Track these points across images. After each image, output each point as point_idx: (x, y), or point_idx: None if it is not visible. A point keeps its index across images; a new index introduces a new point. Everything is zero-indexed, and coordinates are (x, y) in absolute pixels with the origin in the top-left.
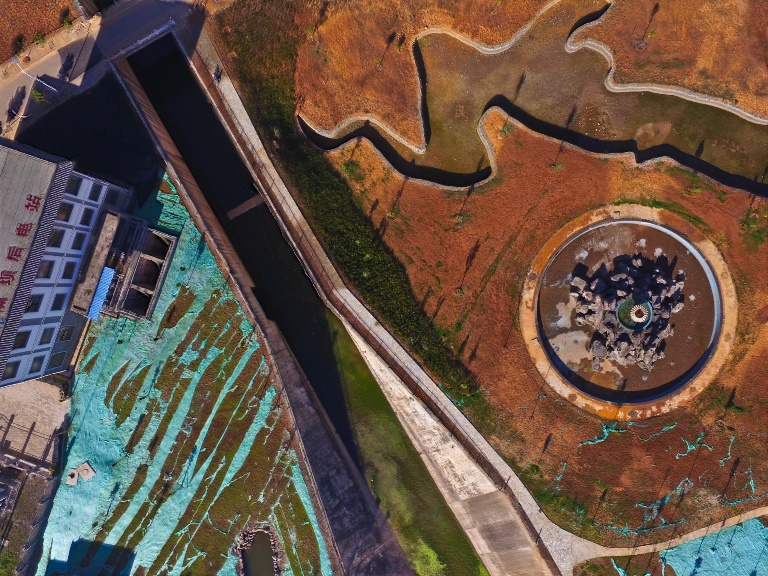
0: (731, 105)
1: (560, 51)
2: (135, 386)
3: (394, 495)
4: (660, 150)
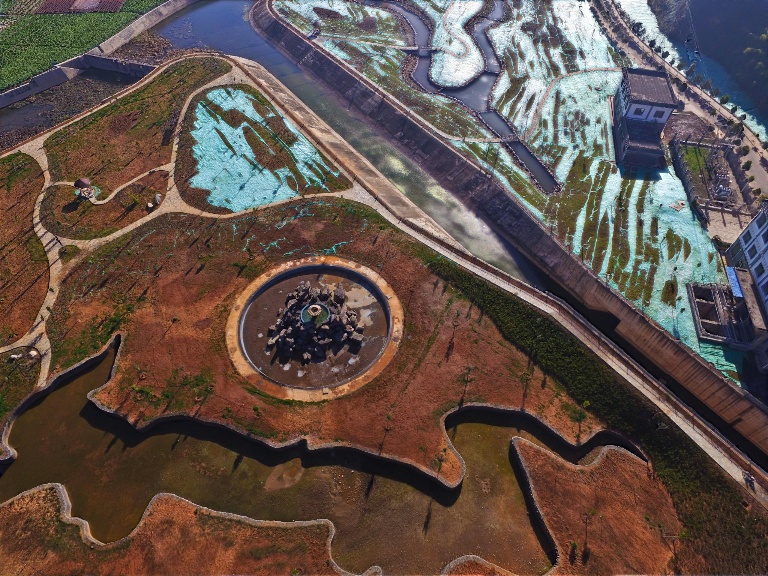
0: (202, 508)
1: (387, 567)
2: (672, 248)
3: (468, 220)
4: (278, 460)
